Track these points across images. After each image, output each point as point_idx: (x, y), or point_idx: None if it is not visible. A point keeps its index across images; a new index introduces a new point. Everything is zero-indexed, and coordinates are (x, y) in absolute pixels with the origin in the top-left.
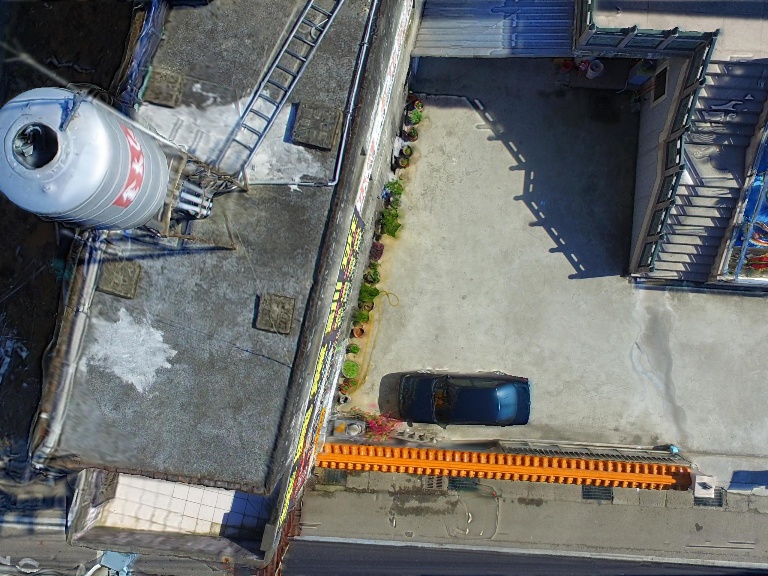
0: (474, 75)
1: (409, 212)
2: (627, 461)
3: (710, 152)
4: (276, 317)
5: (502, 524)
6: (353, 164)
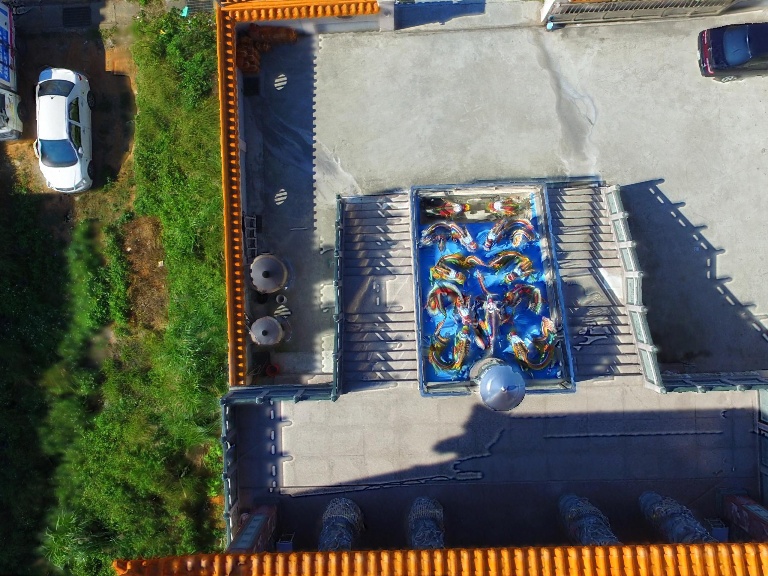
0: None
1: None
2: (621, 2)
3: (586, 300)
4: None
5: None
6: None
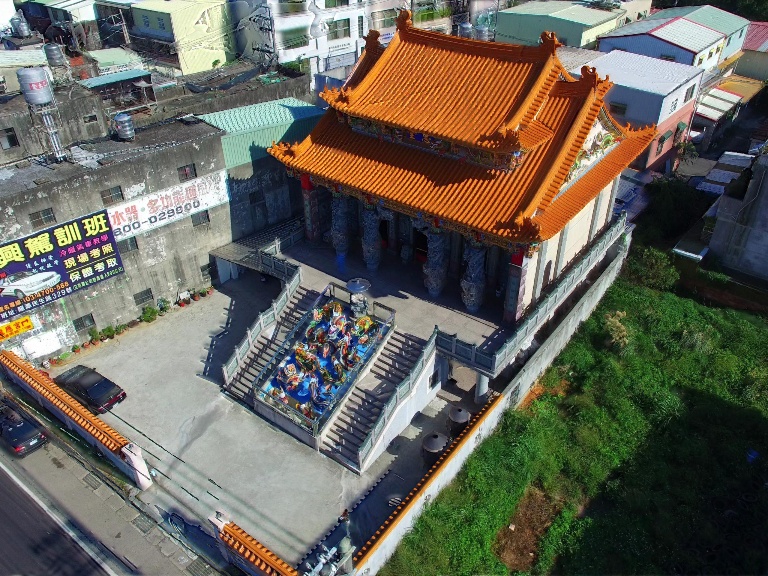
0: (243, 293)
1: (164, 320)
2: None
3: None
4: (41, 180)
5: (31, 464)
6: (107, 176)
